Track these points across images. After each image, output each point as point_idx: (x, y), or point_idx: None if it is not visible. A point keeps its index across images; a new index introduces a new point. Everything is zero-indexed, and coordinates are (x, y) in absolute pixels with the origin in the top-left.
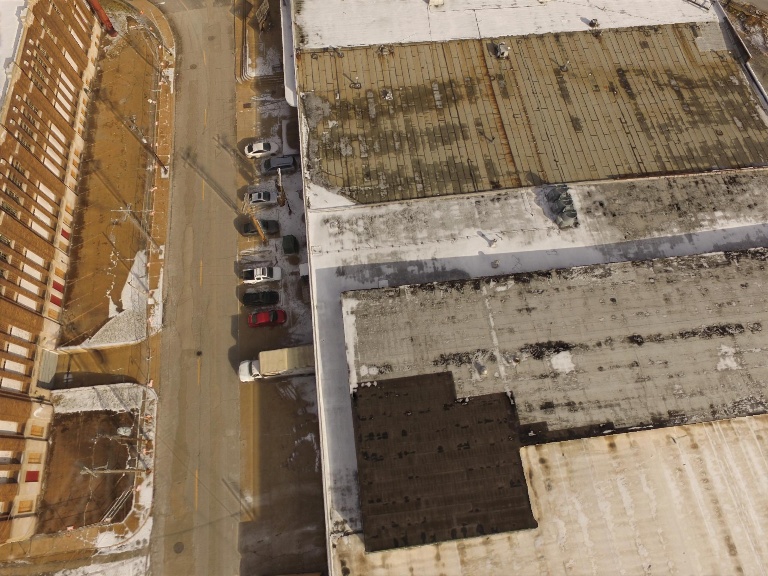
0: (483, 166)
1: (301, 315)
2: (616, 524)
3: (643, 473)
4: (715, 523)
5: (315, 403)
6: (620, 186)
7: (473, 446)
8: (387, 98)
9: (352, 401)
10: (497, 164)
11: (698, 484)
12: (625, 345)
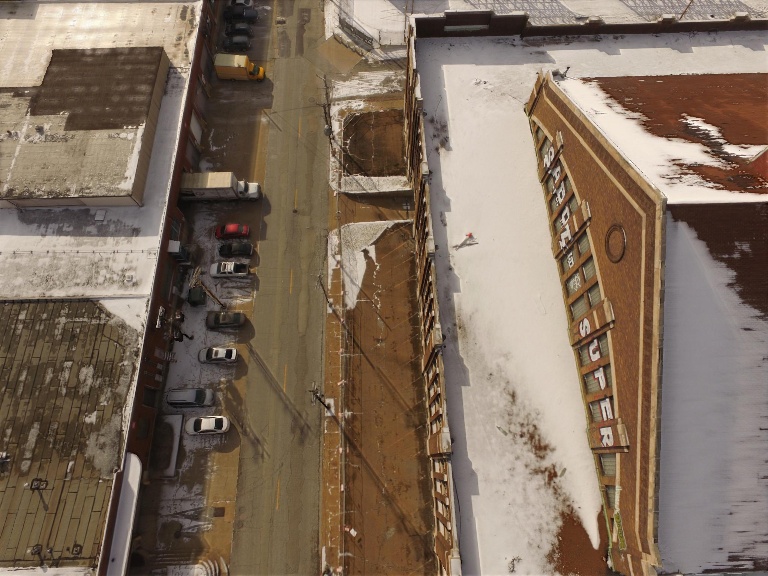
0: None
1: (203, 235)
2: (8, 58)
3: None
4: None
5: (205, 169)
6: None
7: (71, 88)
8: (4, 454)
9: (146, 118)
10: None
11: None
12: None
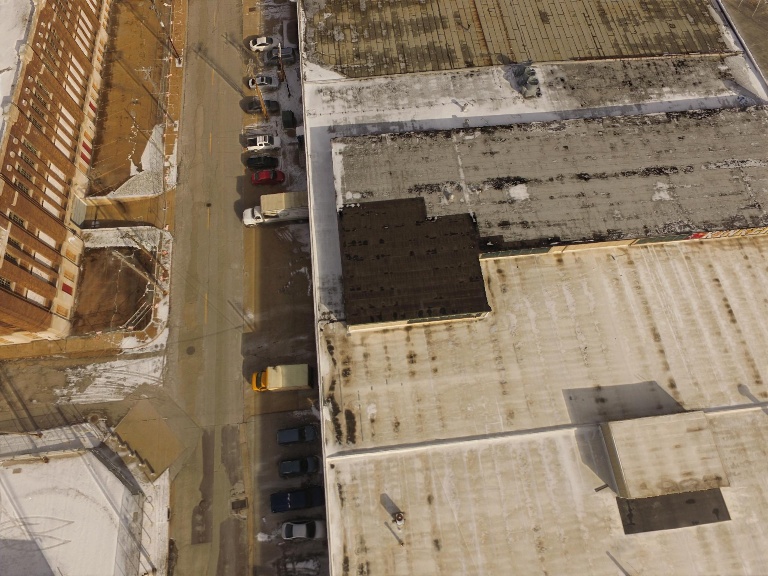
0: (459, 49)
1: (298, 177)
2: (559, 317)
3: (585, 281)
4: (644, 318)
5: (309, 244)
6: (580, 66)
7: (439, 252)
8: None
9: (338, 217)
10: (472, 48)
11: (631, 290)
12: (574, 180)
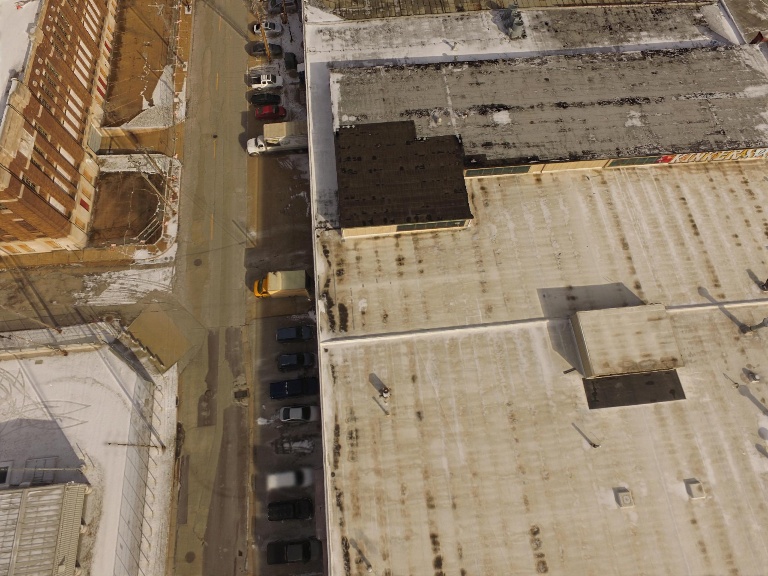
0: None
1: (298, 113)
2: (536, 228)
3: (561, 198)
4: (614, 230)
5: (308, 172)
6: (563, 12)
7: (427, 167)
8: None
9: (335, 137)
10: None
11: (604, 206)
12: (553, 108)
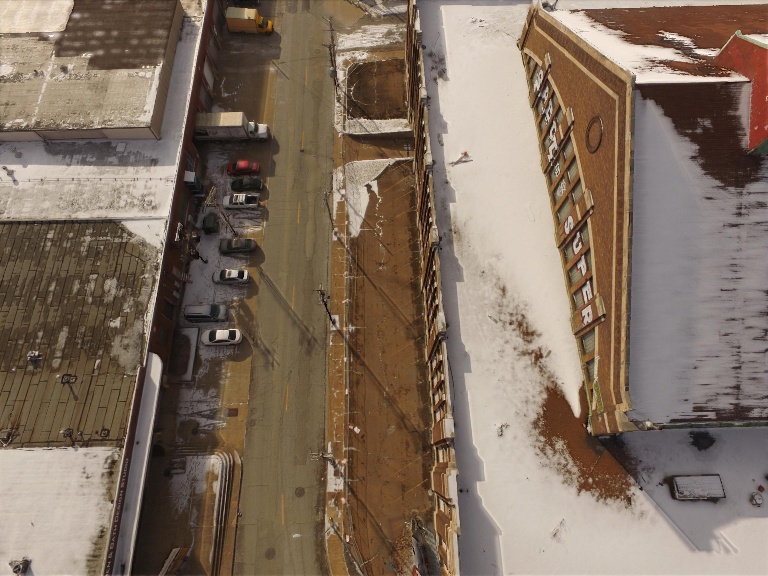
0: None
1: (216, 172)
2: (32, 8)
3: None
4: None
5: None
6: None
7: (93, 33)
8: (36, 353)
9: (163, 59)
10: None
11: None
12: None
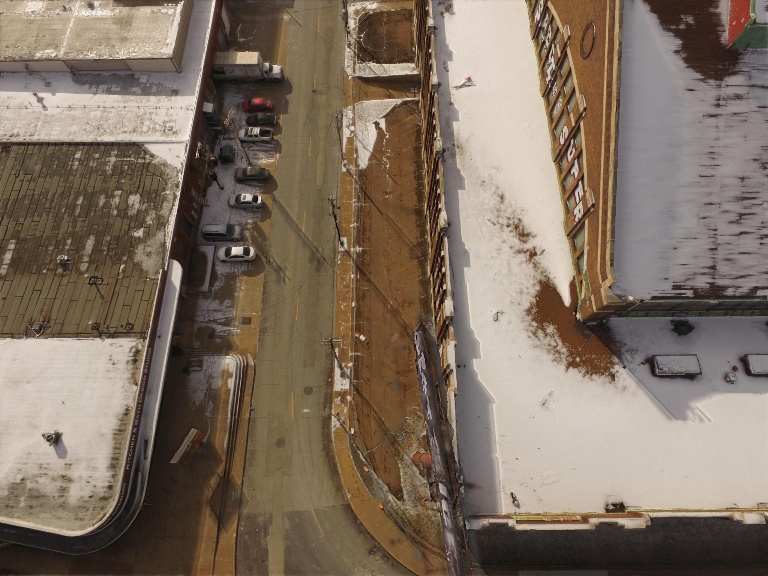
0: (7, 169)
1: None
2: None
3: None
4: None
5: None
6: None
7: None
8: (66, 257)
9: None
10: None
11: None
12: None
